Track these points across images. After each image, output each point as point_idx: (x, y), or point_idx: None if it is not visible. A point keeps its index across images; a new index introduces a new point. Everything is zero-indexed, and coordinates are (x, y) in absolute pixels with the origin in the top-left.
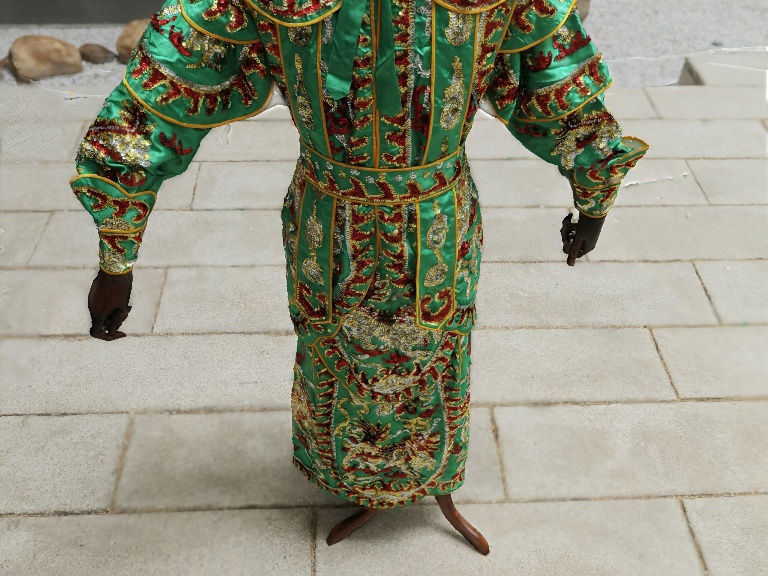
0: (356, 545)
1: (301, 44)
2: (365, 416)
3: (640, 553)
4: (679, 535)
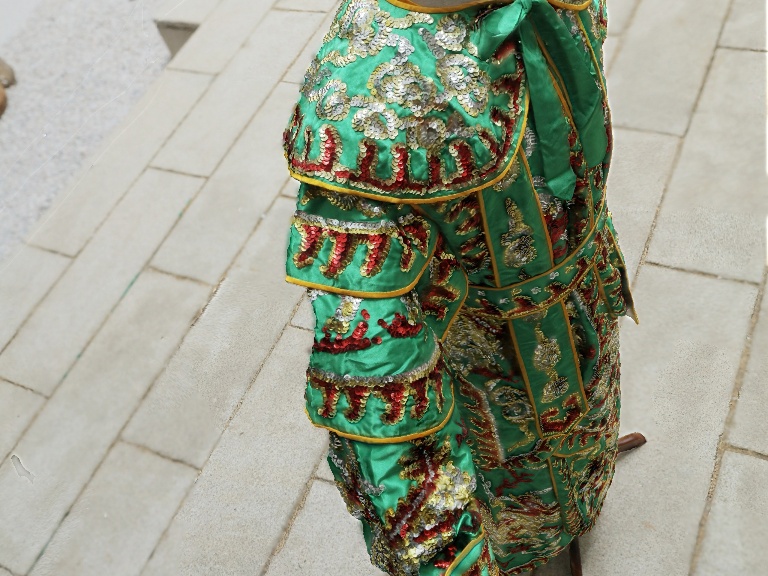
0: (592, 558)
1: (508, 184)
2: (596, 453)
3: (687, 316)
4: (679, 279)
